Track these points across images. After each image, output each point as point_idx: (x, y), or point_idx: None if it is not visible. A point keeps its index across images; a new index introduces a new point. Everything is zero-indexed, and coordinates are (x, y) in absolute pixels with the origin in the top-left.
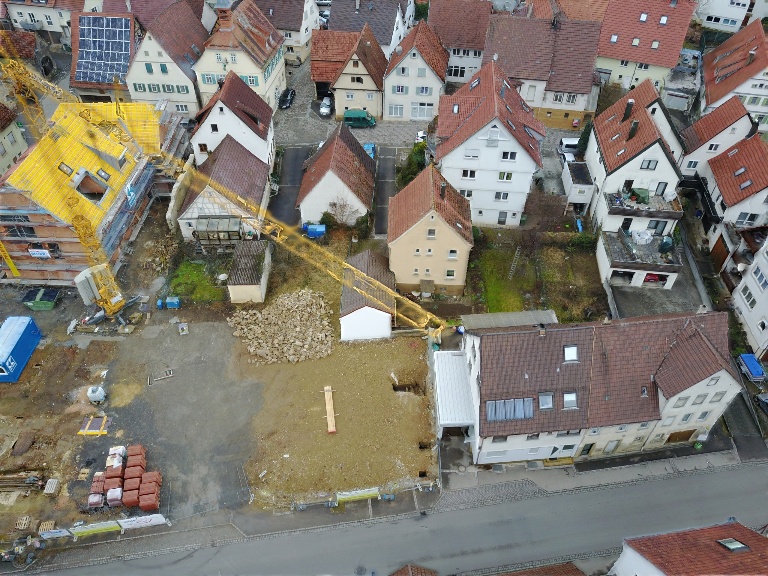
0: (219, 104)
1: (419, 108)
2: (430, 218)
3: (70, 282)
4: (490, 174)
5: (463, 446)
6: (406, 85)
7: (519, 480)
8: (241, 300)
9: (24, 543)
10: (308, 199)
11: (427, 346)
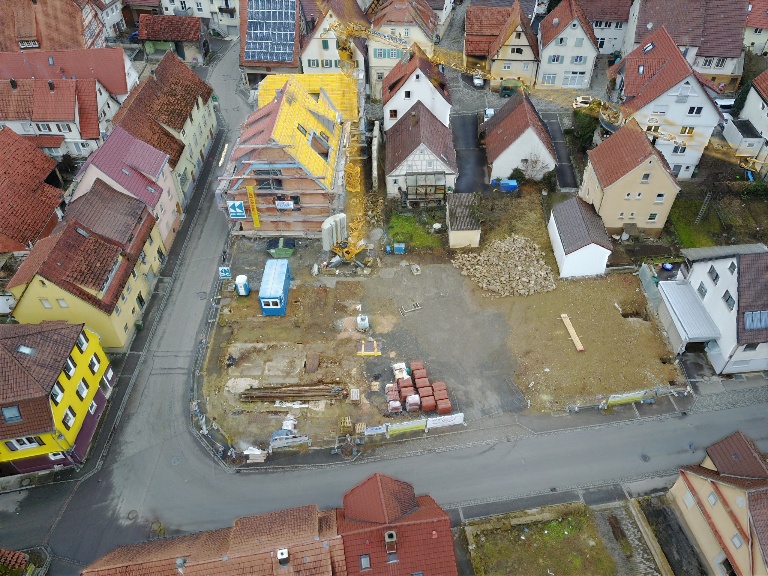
0: (417, 72)
1: (571, 76)
2: (648, 163)
3: (301, 233)
4: (673, 129)
5: (701, 360)
6: (562, 55)
7: (761, 387)
8: (459, 245)
9: (345, 440)
10: (502, 156)
11: (640, 281)
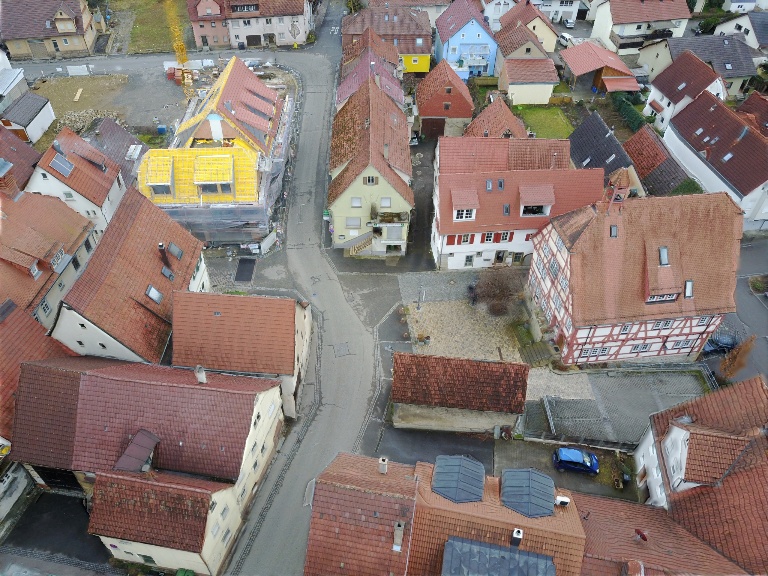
0: None
1: None
2: None
3: None
4: None
5: None
6: None
7: None
8: None
9: None
10: None
11: None
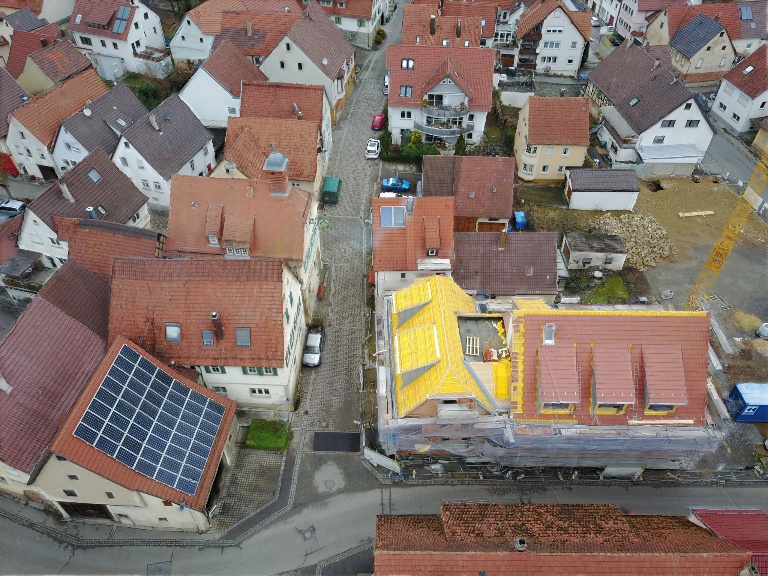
0: None
1: None
2: None
3: None
4: None
5: None
6: (324, 129)
7: None
8: None
9: None
10: None
11: None
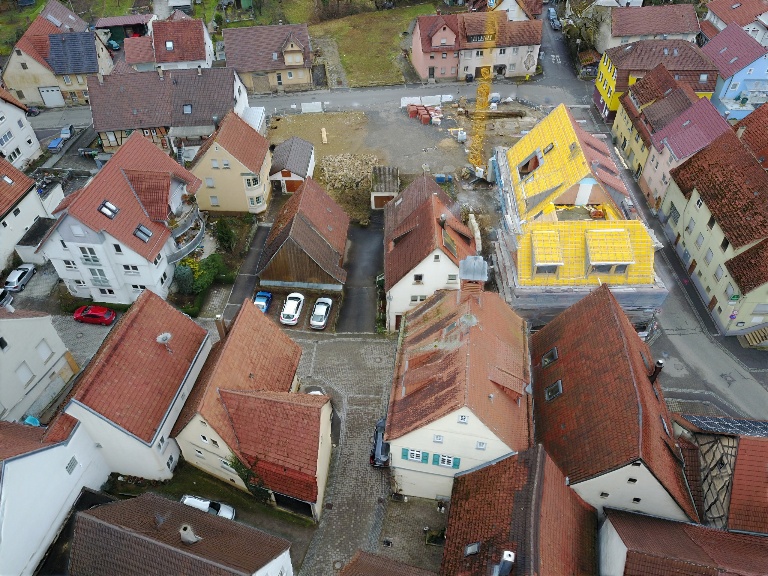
0: None
1: None
2: None
3: None
4: None
5: None
6: None
7: None
8: None
9: None
10: None
11: None
